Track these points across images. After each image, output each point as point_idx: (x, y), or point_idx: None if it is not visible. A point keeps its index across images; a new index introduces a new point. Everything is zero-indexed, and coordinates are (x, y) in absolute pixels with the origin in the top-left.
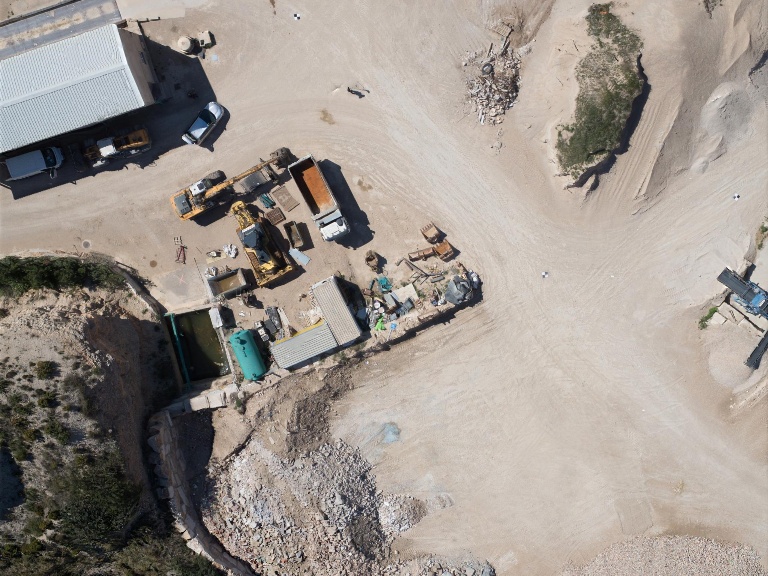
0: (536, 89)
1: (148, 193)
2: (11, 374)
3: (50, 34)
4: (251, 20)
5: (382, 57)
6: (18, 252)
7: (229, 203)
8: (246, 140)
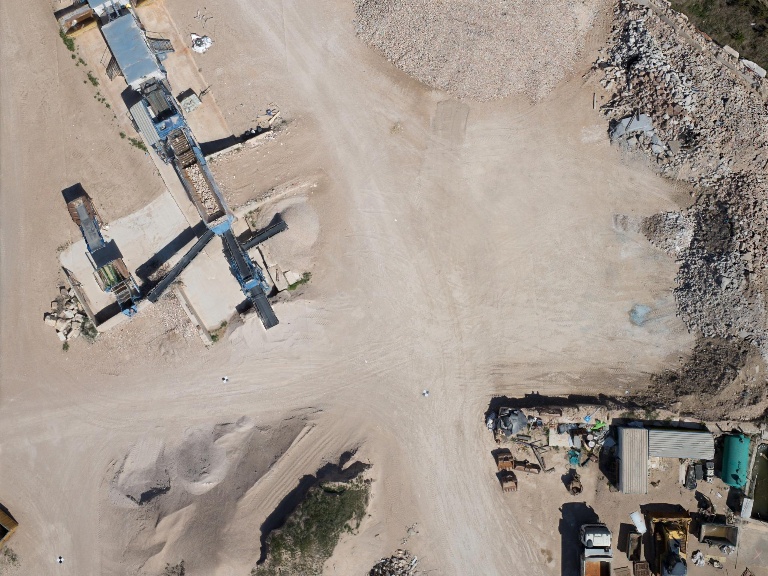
0: (356, 567)
1: None
2: None
3: None
4: None
5: None
6: None
7: None
8: None
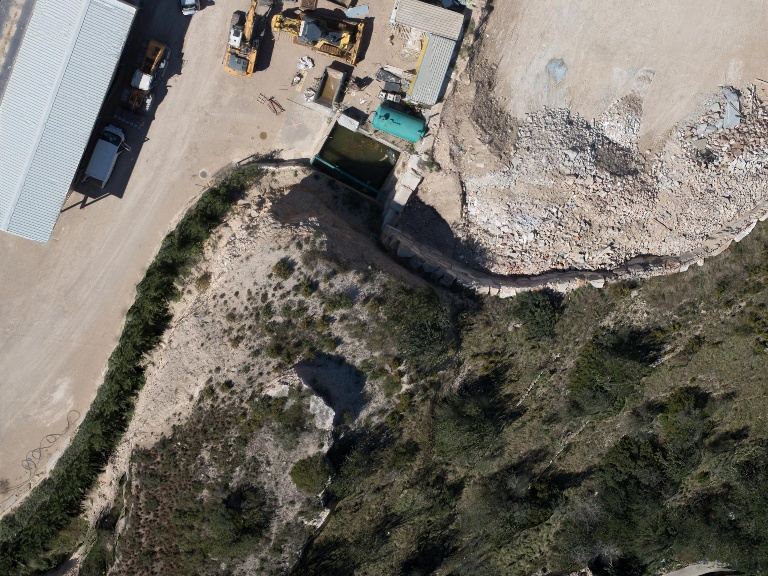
0: None
1: (204, 88)
2: (264, 297)
3: (10, 48)
4: None
5: None
6: (165, 233)
7: (267, 28)
8: None
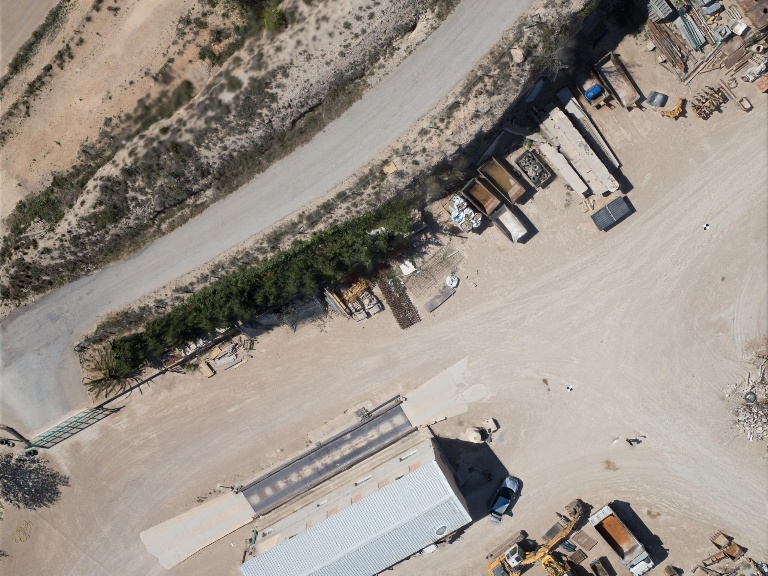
0: None
1: (460, 563)
2: None
3: (349, 453)
4: (528, 400)
5: (652, 406)
6: None
7: None
8: (541, 500)
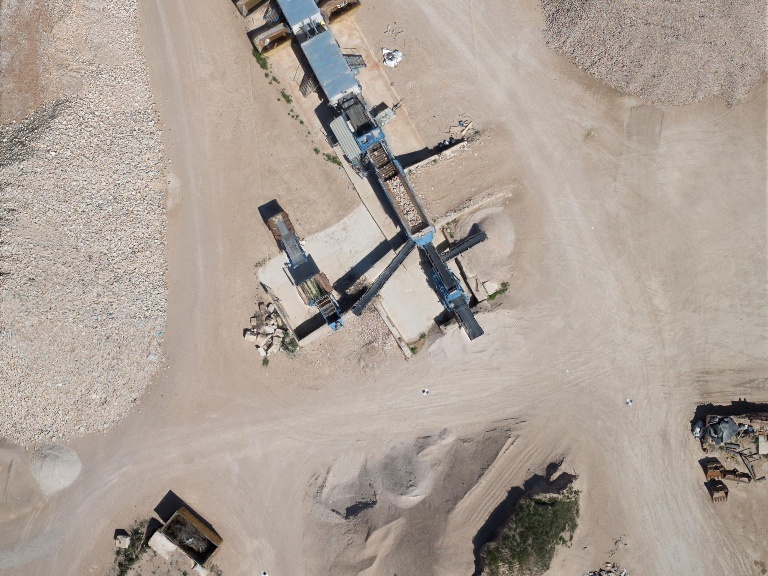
0: None
1: None
2: None
3: None
4: None
5: None
6: None
7: None
8: None
